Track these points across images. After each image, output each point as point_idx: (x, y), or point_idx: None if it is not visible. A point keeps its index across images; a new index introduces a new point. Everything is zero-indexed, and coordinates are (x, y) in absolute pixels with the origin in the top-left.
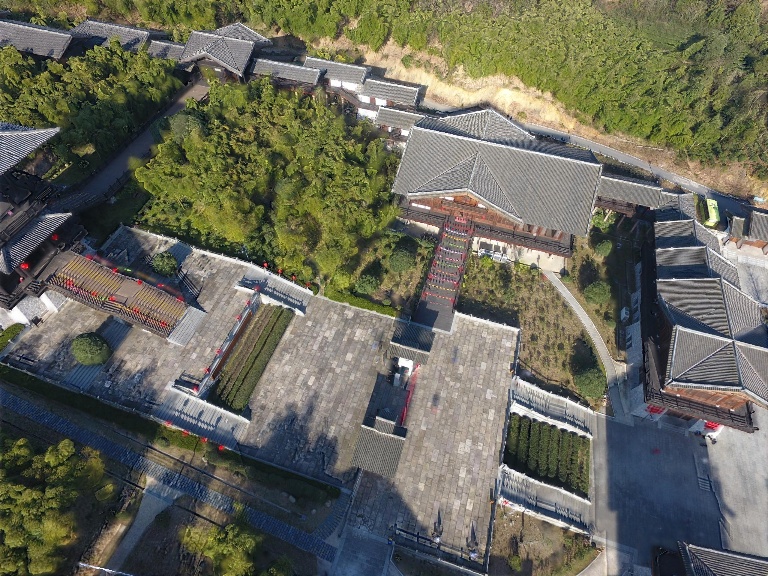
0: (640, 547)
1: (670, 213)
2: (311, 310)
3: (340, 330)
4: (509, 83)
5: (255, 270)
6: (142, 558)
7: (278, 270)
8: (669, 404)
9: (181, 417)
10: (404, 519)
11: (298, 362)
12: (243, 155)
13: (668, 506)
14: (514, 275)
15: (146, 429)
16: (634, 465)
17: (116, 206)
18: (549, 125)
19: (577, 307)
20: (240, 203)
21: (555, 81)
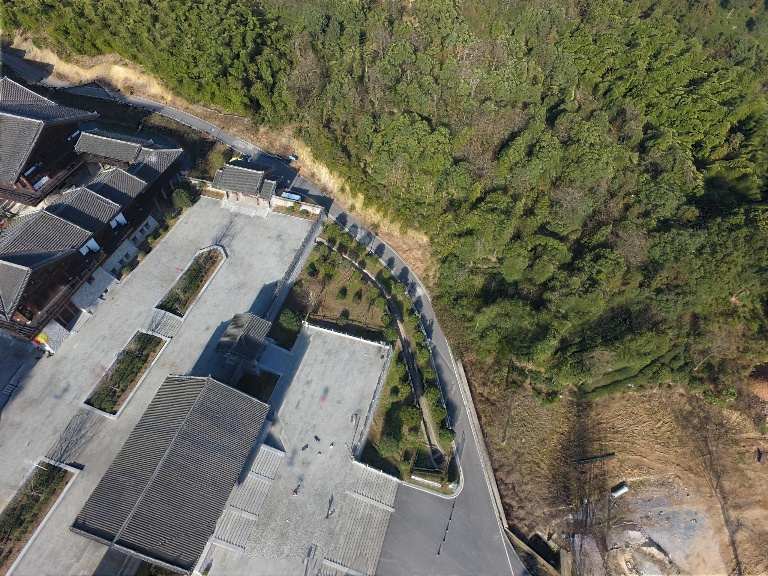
0: None
1: (137, 166)
2: None
3: None
4: (120, 60)
5: None
6: None
7: None
8: None
9: None
10: None
11: None
12: None
13: None
14: None
15: None
16: None
17: None
18: (152, 98)
19: None
20: None
21: None
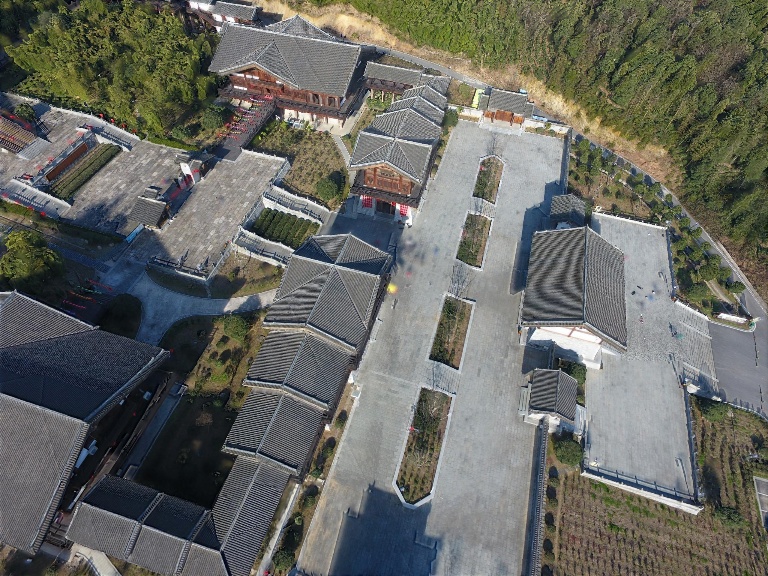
0: None
1: None
2: (136, 149)
3: (153, 160)
4: (346, 10)
5: (95, 121)
6: None
7: (114, 122)
8: (365, 192)
9: (19, 197)
10: (162, 254)
11: (116, 176)
12: (98, 46)
13: None
14: (307, 136)
15: None
16: None
17: None
18: (376, 43)
19: (346, 155)
20: (85, 72)
21: (375, 5)
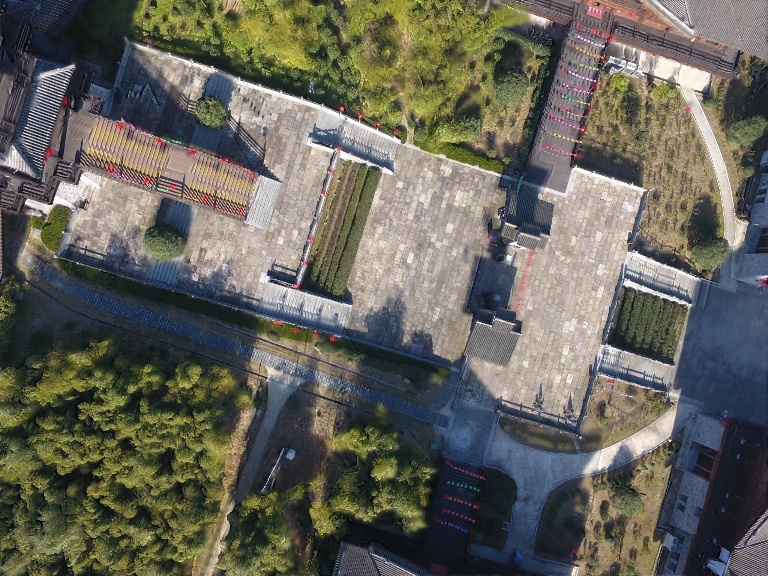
0: (708, 400)
1: None
2: (400, 166)
3: (437, 193)
4: None
5: (327, 114)
6: (284, 434)
7: (355, 111)
8: None
9: (284, 310)
10: (509, 392)
11: (393, 236)
12: None
13: (744, 367)
14: (645, 98)
15: (252, 324)
16: (724, 331)
17: (104, 1)
18: None
19: (713, 147)
20: (296, 9)
21: None
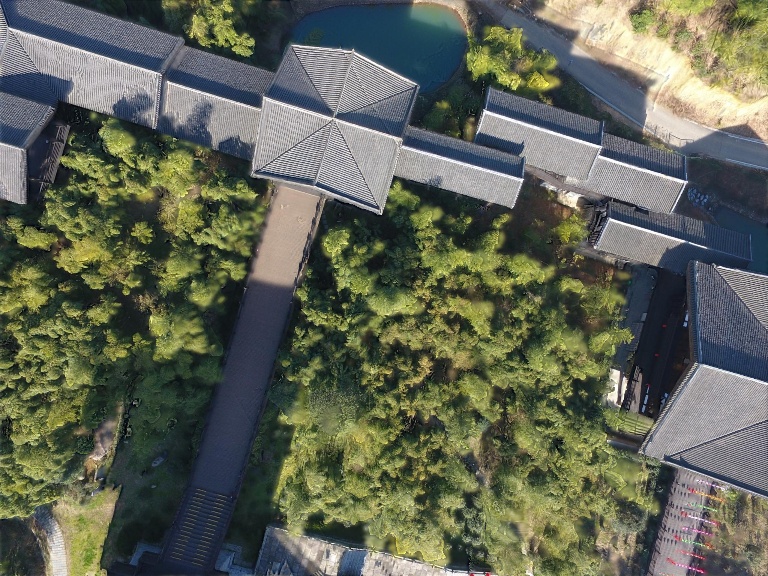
0: None
1: None
2: None
3: None
4: None
5: None
6: None
7: None
8: None
9: None
10: None
11: None
12: (418, 410)
13: None
14: None
15: None
16: None
17: (243, 484)
18: None
19: None
20: (439, 524)
21: None
